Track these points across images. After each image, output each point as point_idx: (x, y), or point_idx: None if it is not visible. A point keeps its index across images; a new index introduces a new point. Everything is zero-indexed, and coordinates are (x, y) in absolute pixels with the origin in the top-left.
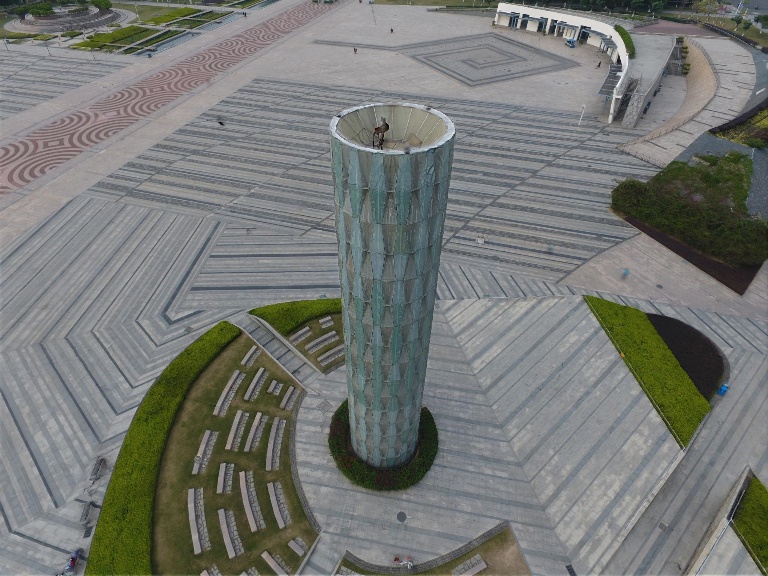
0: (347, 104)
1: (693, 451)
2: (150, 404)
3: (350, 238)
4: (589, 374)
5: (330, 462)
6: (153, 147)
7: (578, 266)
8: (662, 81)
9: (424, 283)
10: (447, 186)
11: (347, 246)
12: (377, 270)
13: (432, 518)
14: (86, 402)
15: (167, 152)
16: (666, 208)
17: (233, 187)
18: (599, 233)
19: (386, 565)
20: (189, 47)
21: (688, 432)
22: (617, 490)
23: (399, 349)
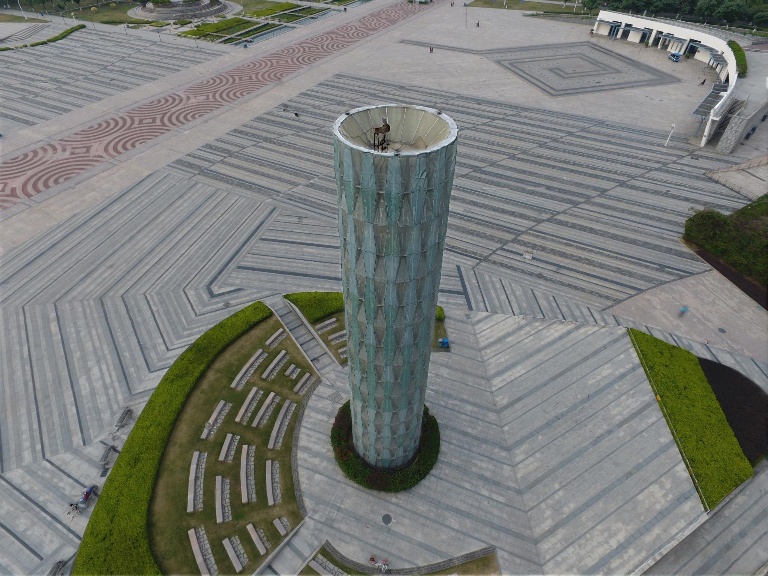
0: None
1: (722, 516)
2: (179, 367)
3: (347, 234)
4: (616, 412)
5: (329, 452)
6: (231, 132)
7: (631, 296)
8: None
9: (419, 288)
10: (446, 193)
11: (344, 242)
12: (370, 269)
13: (417, 527)
14: (127, 356)
15: (242, 137)
16: (746, 245)
17: (295, 176)
18: (663, 264)
19: (362, 563)
20: (282, 40)
21: (717, 494)
22: (621, 540)
23: (392, 351)
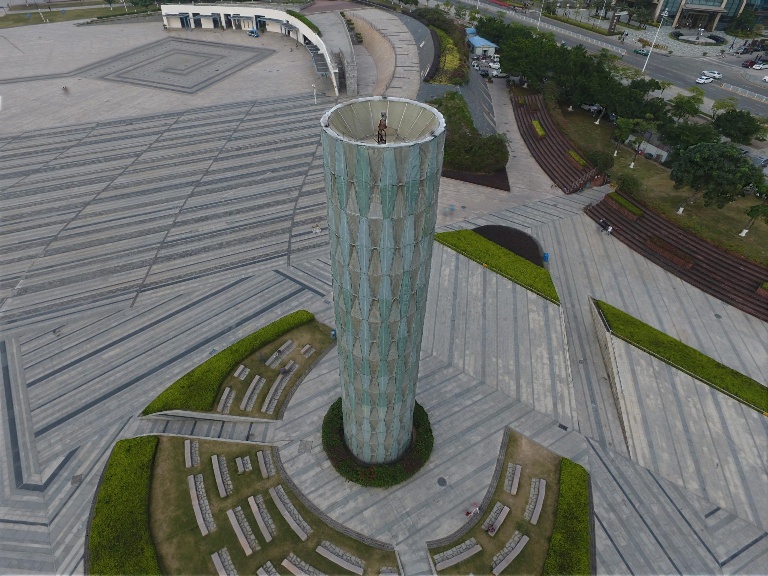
0: (63, 148)
1: None
2: None
3: (375, 243)
4: (475, 290)
5: (353, 487)
6: None
7: None
8: None
9: None
10: None
11: (371, 253)
12: (405, 262)
13: (462, 465)
14: None
15: None
16: None
17: None
18: None
19: (461, 526)
20: None
21: (554, 293)
22: (547, 356)
23: (416, 331)
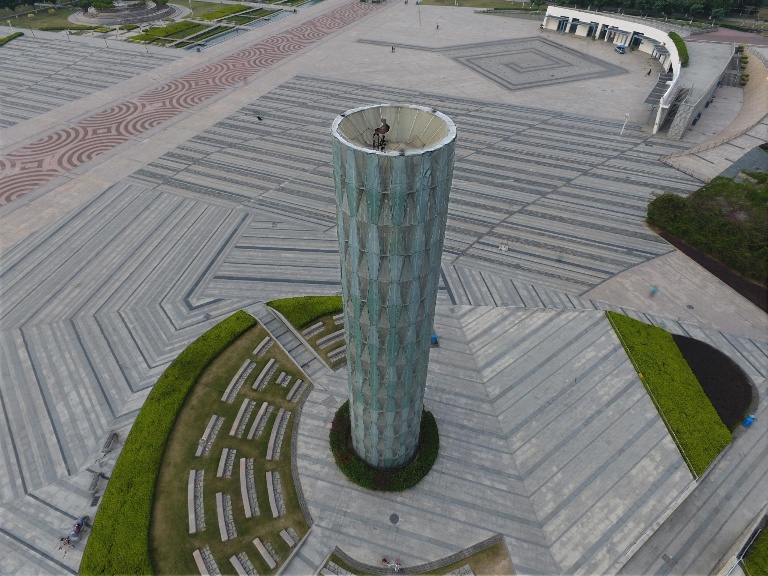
0: None
1: (708, 482)
2: (164, 385)
3: (348, 237)
4: (603, 392)
5: (329, 457)
6: (193, 138)
7: (604, 280)
8: (716, 92)
9: (422, 286)
10: (447, 190)
11: (345, 244)
12: (373, 270)
13: (425, 523)
14: (106, 378)
15: (205, 144)
16: (705, 225)
17: (264, 181)
18: (630, 247)
19: (374, 565)
20: (236, 43)
21: (704, 462)
22: (620, 515)
23: (396, 351)
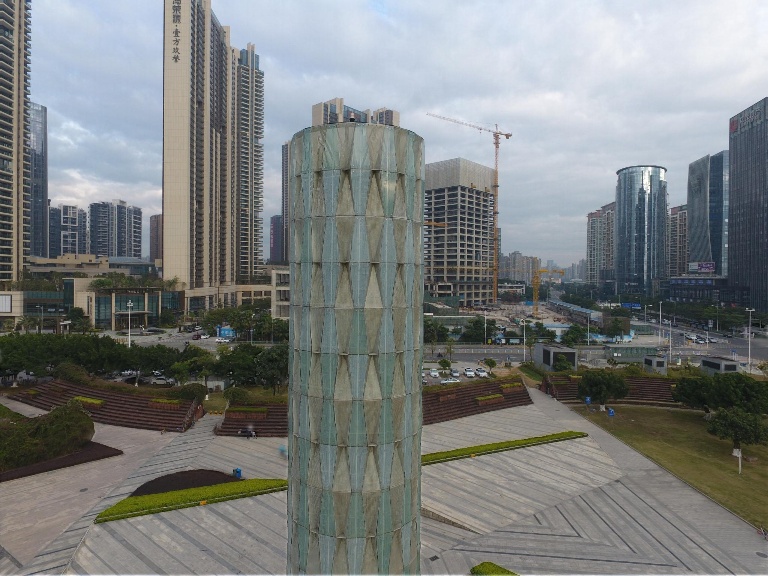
0: None
1: None
2: None
3: None
4: (223, 529)
5: None
6: None
7: None
8: None
9: None
10: None
11: None
12: None
13: None
14: None
15: None
16: None
17: None
18: None
19: None
20: None
21: None
22: None
23: None
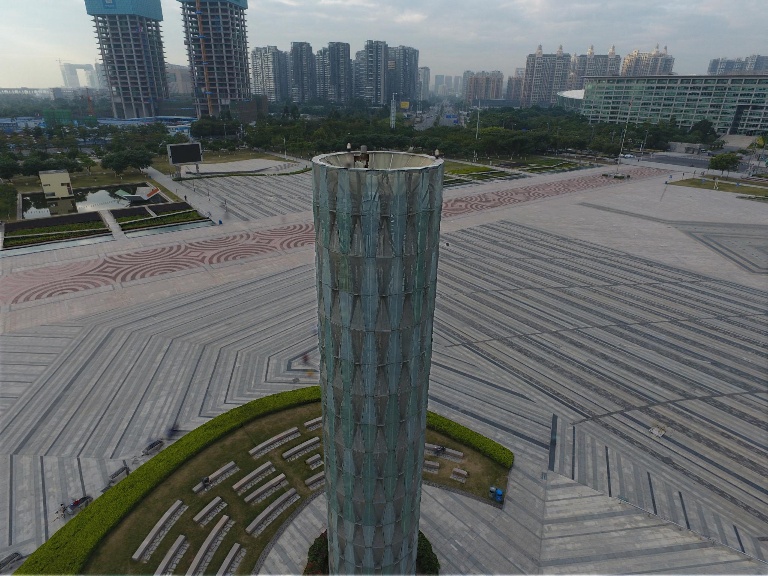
0: (578, 256)
1: None
2: (220, 419)
3: None
4: None
5: (302, 565)
6: None
7: None
8: None
9: (382, 348)
10: (415, 232)
11: None
12: None
13: None
14: (191, 396)
15: None
16: None
17: None
18: None
19: None
20: (465, 191)
21: None
22: None
23: (352, 428)
